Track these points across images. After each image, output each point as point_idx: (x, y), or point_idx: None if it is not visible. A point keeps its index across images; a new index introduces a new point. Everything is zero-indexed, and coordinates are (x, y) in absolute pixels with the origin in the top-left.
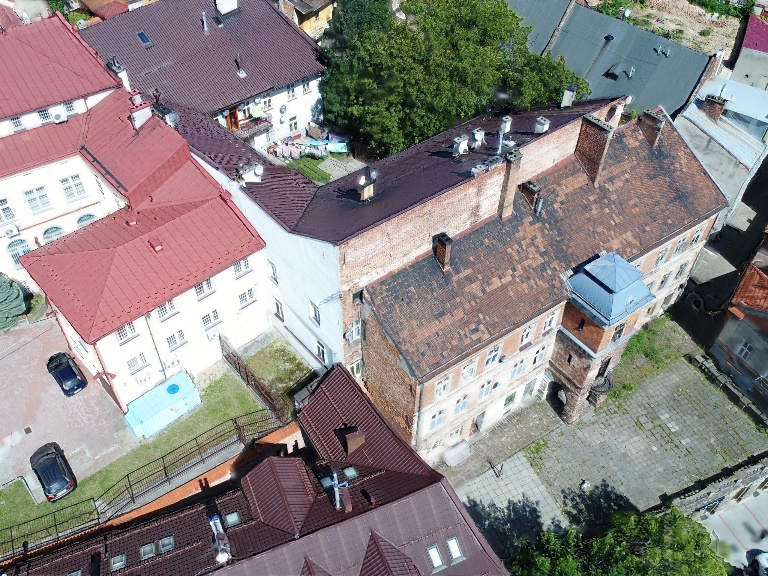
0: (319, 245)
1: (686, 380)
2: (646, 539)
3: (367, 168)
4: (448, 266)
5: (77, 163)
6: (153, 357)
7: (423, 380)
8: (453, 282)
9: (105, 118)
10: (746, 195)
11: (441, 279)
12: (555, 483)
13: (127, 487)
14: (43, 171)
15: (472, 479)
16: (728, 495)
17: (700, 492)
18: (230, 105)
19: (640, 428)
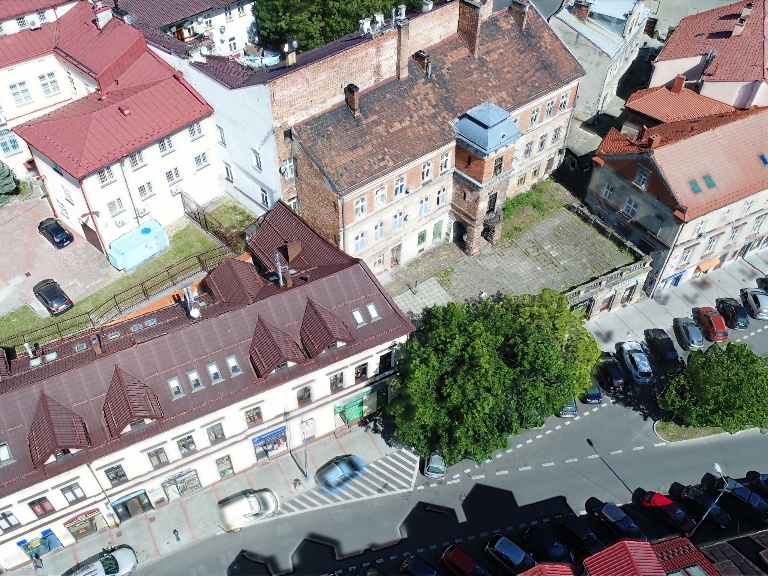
0: (254, 90)
1: (566, 222)
2: None
3: (289, 37)
4: (358, 112)
5: (52, 62)
6: (128, 204)
7: (342, 194)
8: (363, 125)
9: (73, 24)
10: (620, 91)
11: (353, 122)
12: (460, 295)
13: (114, 305)
14: (24, 67)
15: (394, 297)
16: (597, 298)
17: (572, 291)
18: (177, 22)
19: (528, 256)
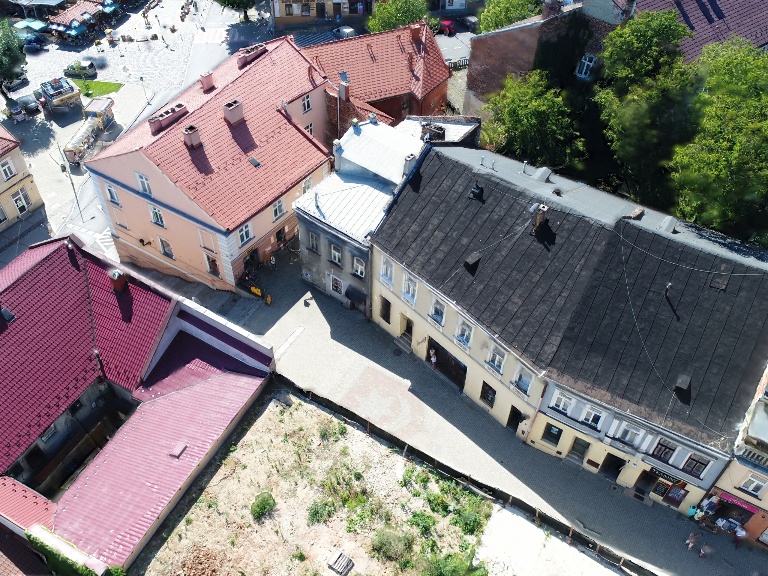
0: None
1: None
2: (528, 12)
3: None
4: None
5: None
6: None
7: None
8: None
9: None
10: None
11: None
12: None
13: None
14: None
15: None
16: None
17: None
18: None
19: None
